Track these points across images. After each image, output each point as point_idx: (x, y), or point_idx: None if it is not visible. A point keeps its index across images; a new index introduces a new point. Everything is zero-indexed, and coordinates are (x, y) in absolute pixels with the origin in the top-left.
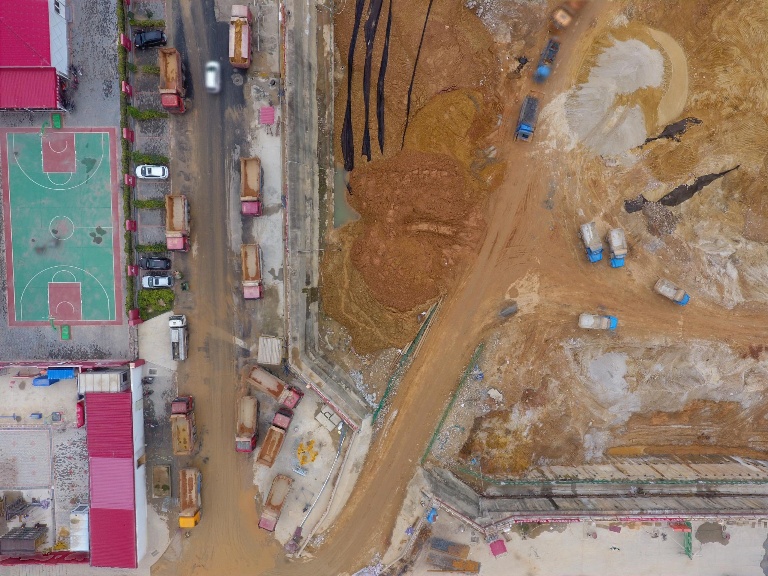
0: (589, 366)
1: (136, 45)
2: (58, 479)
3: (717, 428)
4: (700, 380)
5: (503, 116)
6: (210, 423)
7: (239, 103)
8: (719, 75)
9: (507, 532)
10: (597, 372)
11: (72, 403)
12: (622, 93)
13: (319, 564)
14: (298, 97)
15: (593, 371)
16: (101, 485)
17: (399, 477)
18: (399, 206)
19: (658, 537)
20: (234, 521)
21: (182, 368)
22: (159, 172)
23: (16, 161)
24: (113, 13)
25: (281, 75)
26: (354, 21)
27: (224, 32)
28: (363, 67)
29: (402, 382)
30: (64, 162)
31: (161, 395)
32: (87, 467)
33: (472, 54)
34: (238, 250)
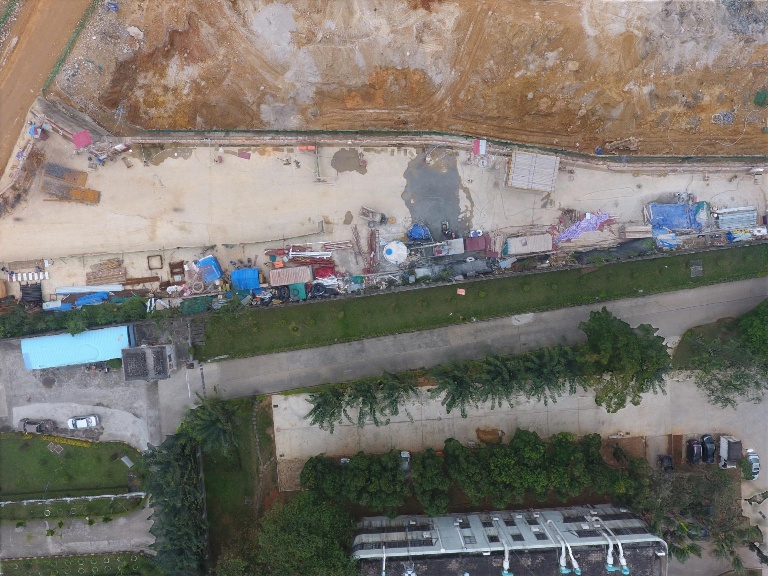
0: (252, 19)
1: None
2: None
3: (415, 113)
4: (370, 33)
5: None
6: None
7: None
8: None
9: (127, 158)
10: (258, 22)
11: None
12: None
13: None
14: None
15: (256, 23)
16: None
17: (18, 107)
18: None
19: (290, 164)
20: None
21: None
22: None
23: None
24: None
25: None
26: None
27: None
28: None
29: (23, 8)
30: None
31: None
32: None
33: None
34: None
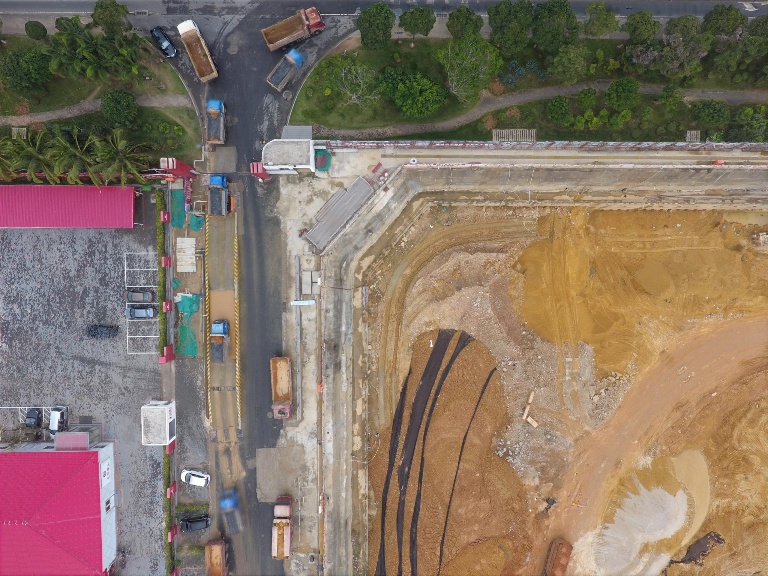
0: None
1: (182, 530)
2: None
3: None
4: None
5: (531, 553)
6: None
7: (279, 575)
8: (740, 482)
9: None
10: None
11: None
12: (647, 542)
13: None
14: (336, 567)
15: None
16: None
17: None
18: None
19: None
20: None
21: None
22: None
23: None
24: (160, 497)
25: (320, 552)
26: (388, 464)
27: (265, 511)
28: (396, 509)
29: None
30: None
31: None
32: None
33: (502, 504)
34: None
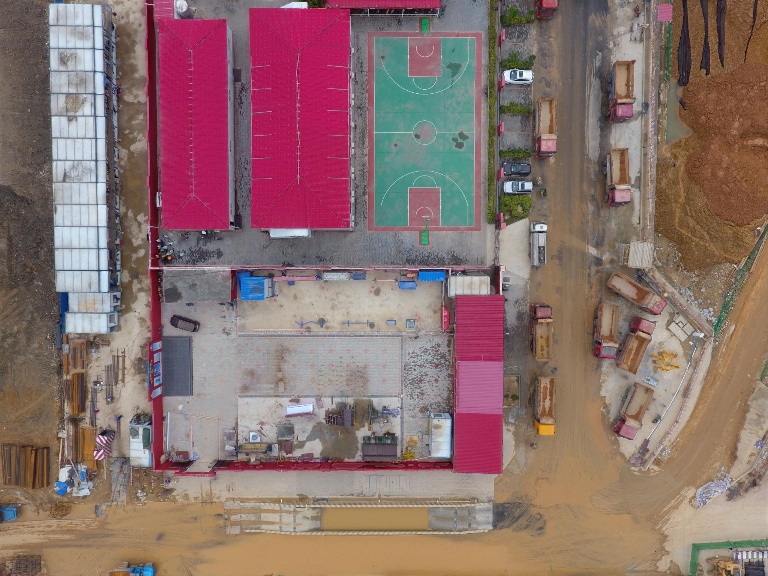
0: None
1: None
2: (408, 387)
3: None
4: None
5: None
6: (560, 333)
7: (603, 10)
8: None
9: None
10: None
11: (426, 310)
12: None
13: (665, 477)
14: None
15: None
16: (468, 389)
17: (739, 392)
18: (742, 119)
19: None
20: (579, 433)
21: (534, 276)
22: (530, 76)
23: (383, 65)
24: None
25: None
26: None
27: None
28: None
29: (738, 297)
30: (430, 67)
31: (513, 303)
32: (437, 375)
33: None
34: (595, 157)
